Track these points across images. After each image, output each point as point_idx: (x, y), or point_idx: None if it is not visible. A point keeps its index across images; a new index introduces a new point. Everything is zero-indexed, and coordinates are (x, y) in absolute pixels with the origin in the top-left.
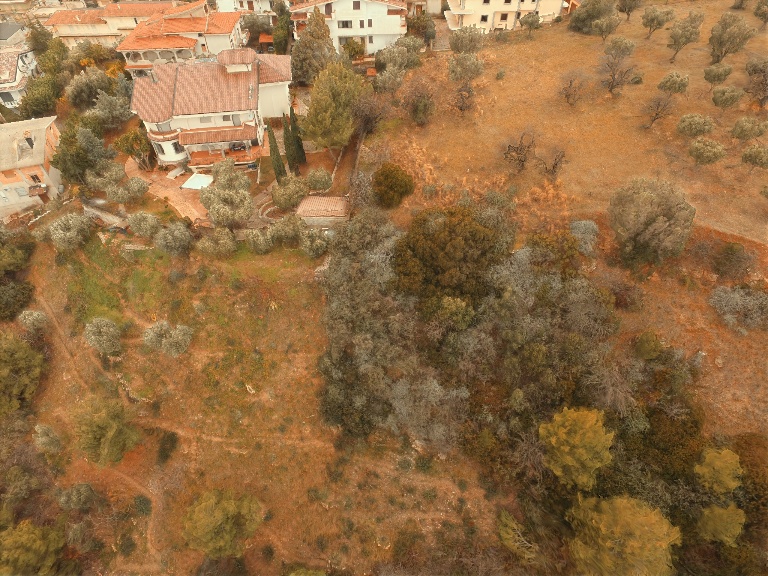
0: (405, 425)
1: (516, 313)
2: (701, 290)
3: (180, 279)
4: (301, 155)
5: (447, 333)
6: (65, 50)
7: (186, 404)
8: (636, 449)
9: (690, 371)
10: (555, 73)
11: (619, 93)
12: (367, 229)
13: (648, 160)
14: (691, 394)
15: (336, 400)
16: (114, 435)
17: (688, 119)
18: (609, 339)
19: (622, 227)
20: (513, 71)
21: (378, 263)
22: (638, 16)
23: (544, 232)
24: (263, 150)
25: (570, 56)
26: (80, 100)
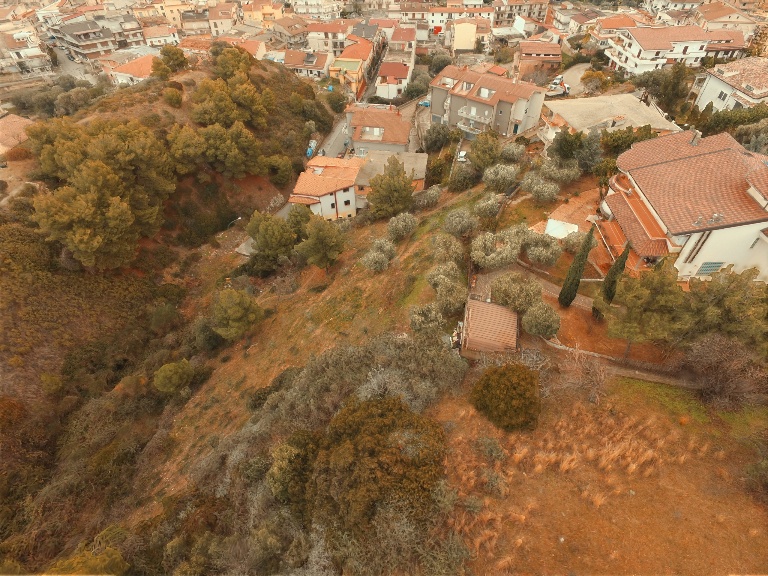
0: None
1: None
2: None
3: None
4: None
5: None
6: None
7: None
8: None
9: None
10: None
11: None
12: None
13: None
14: None
15: (285, 378)
16: (316, 249)
17: None
18: None
19: None
20: None
21: None
22: None
23: None
24: None
25: None
26: (740, 140)
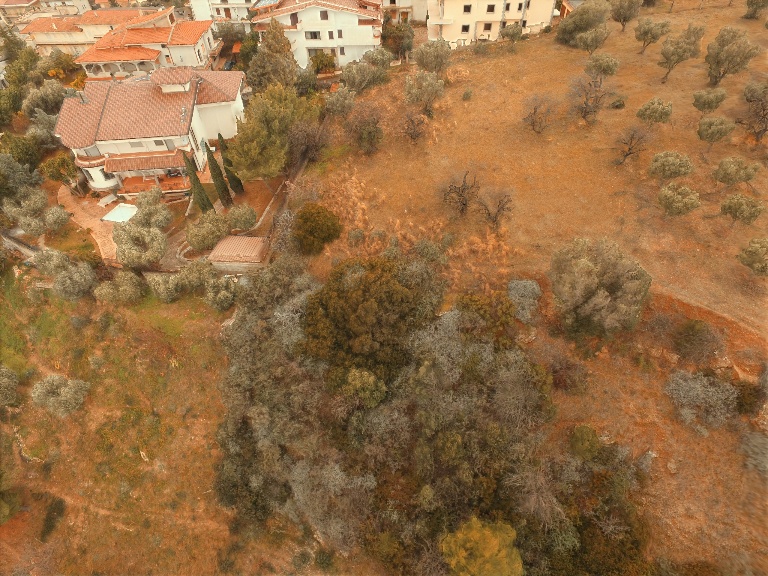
0: (304, 513)
1: (434, 391)
2: (658, 373)
3: (86, 324)
4: (236, 184)
5: (353, 411)
6: (37, 60)
7: (78, 467)
8: (564, 569)
9: (636, 475)
10: (529, 93)
11: (594, 120)
12: (279, 280)
13: (613, 205)
14: (635, 505)
15: (231, 478)
16: None
17: (661, 159)
18: (543, 427)
19: (558, 298)
20: (483, 90)
21: (285, 322)
22: (635, 26)
23: (478, 292)
24: (202, 176)
25: (550, 73)
26: None
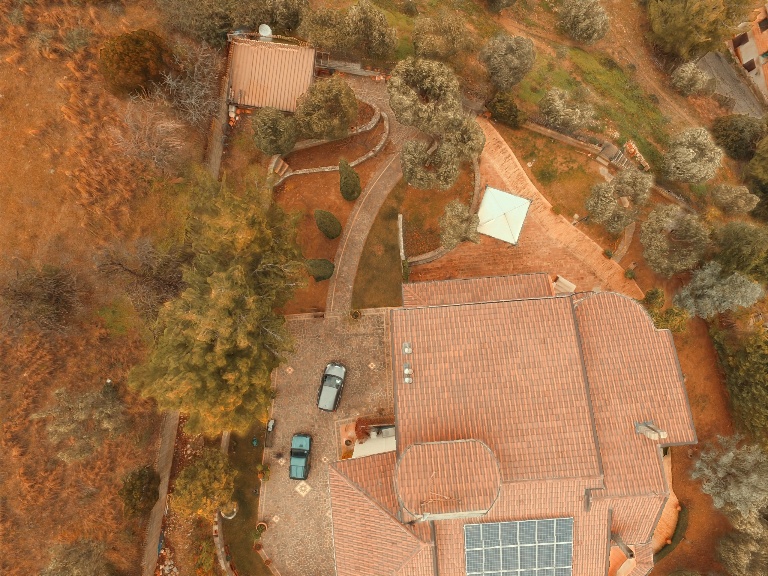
0: None
1: None
2: None
3: None
4: None
5: None
6: None
7: None
8: None
9: None
10: None
11: None
12: None
13: None
14: None
15: None
16: None
17: None
18: None
19: None
20: None
21: None
22: None
23: None
24: None
25: None
26: None
